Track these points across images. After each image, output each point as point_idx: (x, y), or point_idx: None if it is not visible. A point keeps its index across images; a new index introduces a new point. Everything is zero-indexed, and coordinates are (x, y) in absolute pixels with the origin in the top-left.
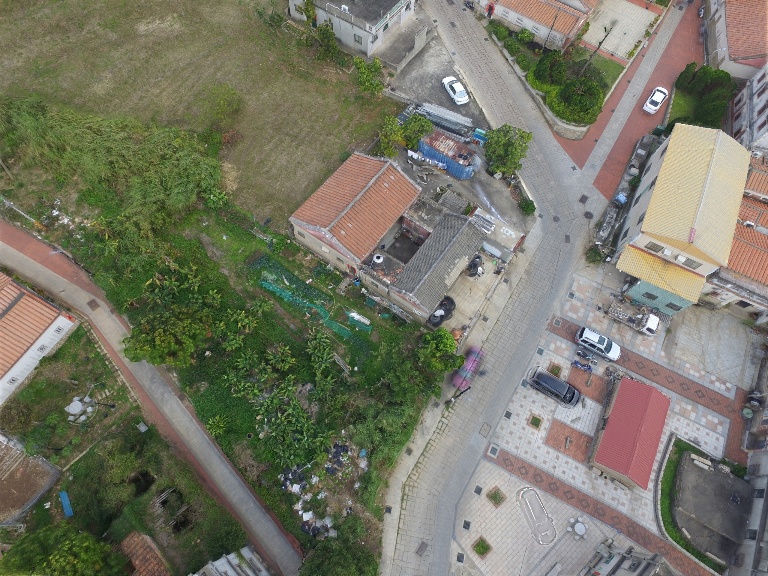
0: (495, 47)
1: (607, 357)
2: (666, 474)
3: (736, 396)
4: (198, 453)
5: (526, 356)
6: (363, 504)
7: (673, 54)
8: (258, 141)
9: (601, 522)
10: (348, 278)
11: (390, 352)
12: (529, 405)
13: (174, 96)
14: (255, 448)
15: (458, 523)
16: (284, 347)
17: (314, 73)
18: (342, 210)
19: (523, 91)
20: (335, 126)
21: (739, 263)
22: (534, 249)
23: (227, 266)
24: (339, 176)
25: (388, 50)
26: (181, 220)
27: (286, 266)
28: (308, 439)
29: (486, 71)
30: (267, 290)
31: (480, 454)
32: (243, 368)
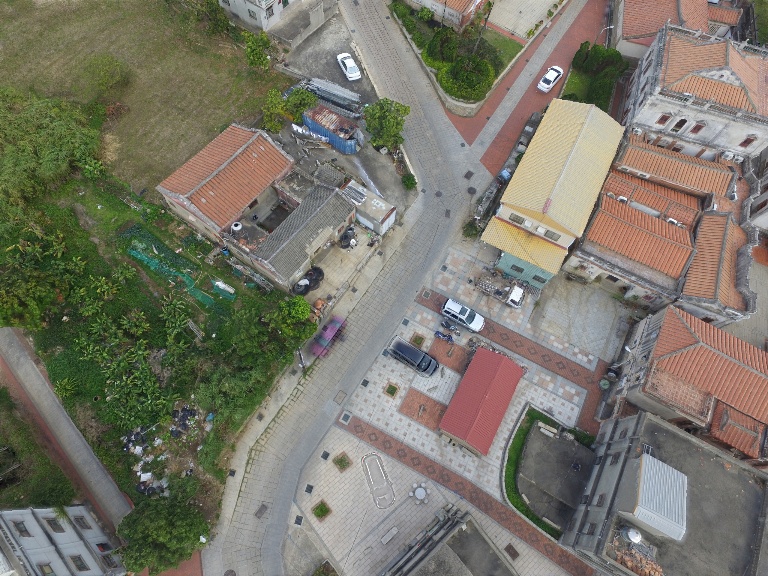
0: (396, 25)
1: (469, 328)
2: (515, 442)
3: (597, 368)
4: (47, 416)
5: (391, 326)
6: (202, 466)
7: (575, 34)
8: (144, 114)
9: (445, 488)
10: (218, 248)
11: (243, 318)
12: (387, 374)
13: (64, 68)
14: (100, 410)
15: (301, 487)
16: (140, 313)
17: (210, 48)
18: (205, 178)
19: (419, 68)
20: (224, 100)
21: (604, 236)
22: (413, 223)
23: (98, 235)
24: (212, 147)
25: (286, 26)
26: (57, 189)
27: (158, 236)
28: (152, 402)
29: (384, 48)
30: (135, 258)
31: (332, 421)
32: (96, 333)
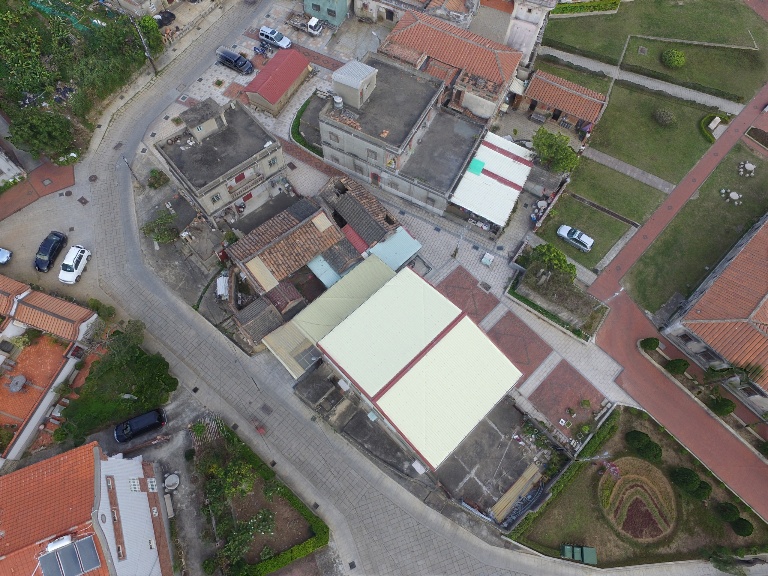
0: None
1: (278, 45)
2: (302, 108)
3: None
4: None
5: None
6: (75, 114)
7: None
8: None
9: None
10: (98, 1)
11: None
12: (217, 75)
13: None
14: (4, 85)
15: (147, 134)
16: (34, 30)
17: None
18: None
19: None
20: None
21: None
22: None
23: None
24: None
25: None
26: None
27: None
28: (40, 77)
29: None
30: (35, 7)
31: (173, 99)
32: (2, 42)
